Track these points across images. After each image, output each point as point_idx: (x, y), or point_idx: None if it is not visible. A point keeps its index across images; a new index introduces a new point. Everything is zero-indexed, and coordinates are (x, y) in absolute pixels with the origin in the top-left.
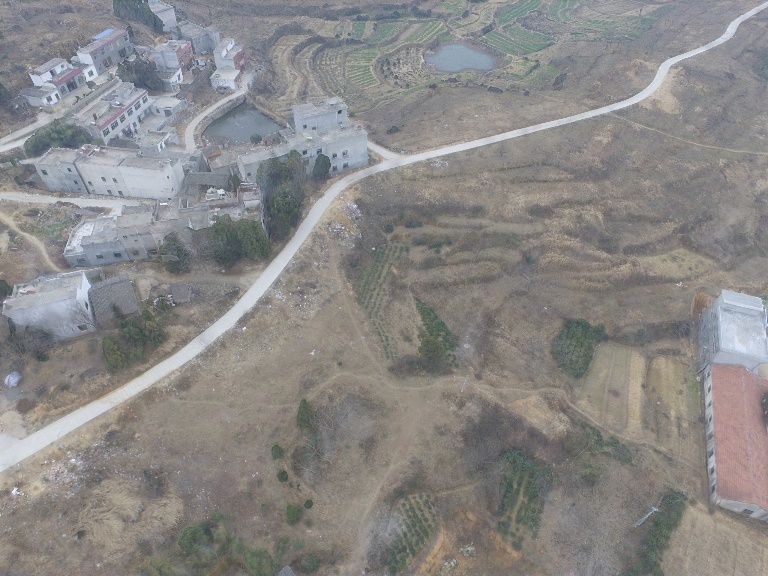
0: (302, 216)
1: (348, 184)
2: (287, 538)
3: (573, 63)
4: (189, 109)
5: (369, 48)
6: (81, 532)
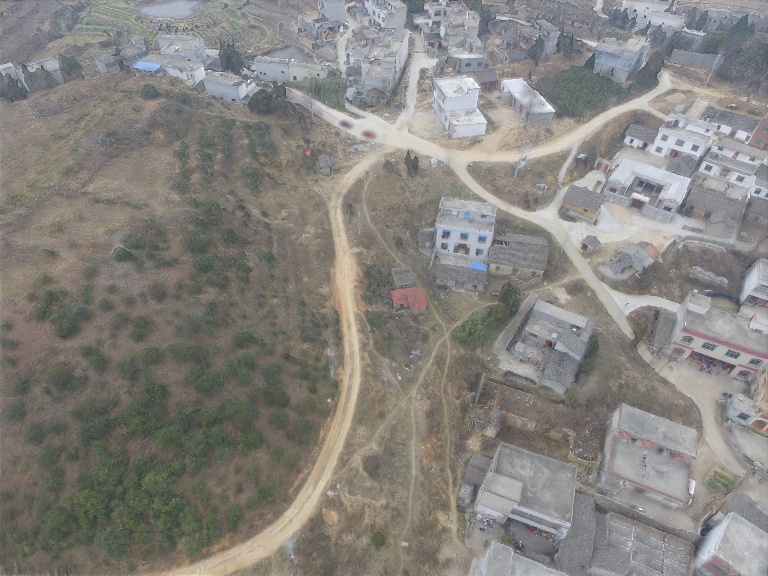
0: None
1: None
2: None
3: None
4: None
5: (129, 33)
6: None
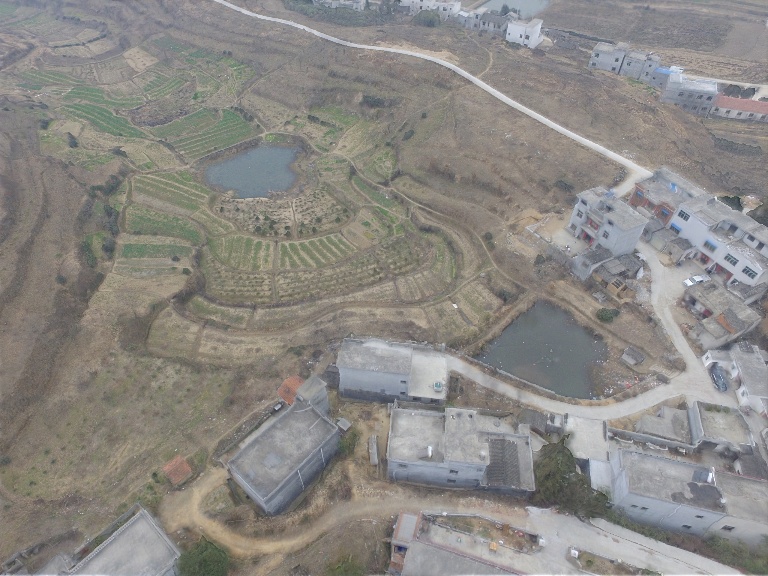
0: None
1: None
2: None
3: (337, 90)
4: None
5: (211, 246)
6: None
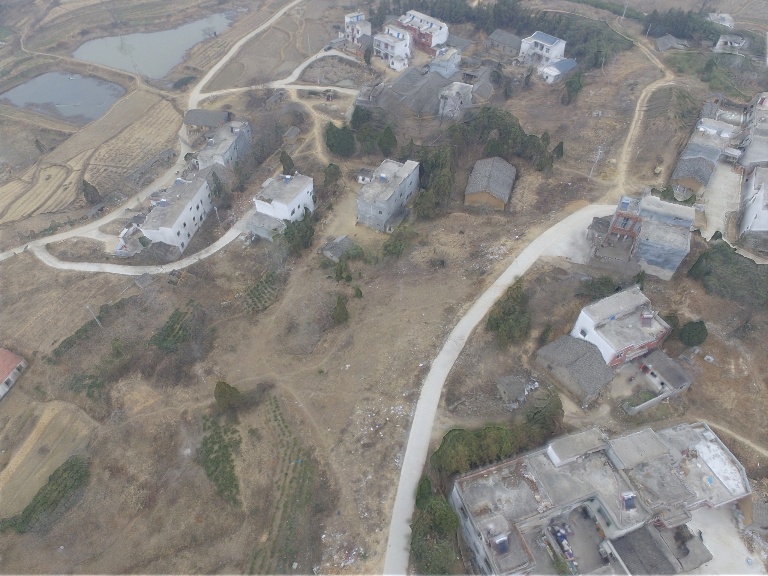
0: (414, 569)
1: None
2: None
3: None
4: None
5: None
6: (461, 232)
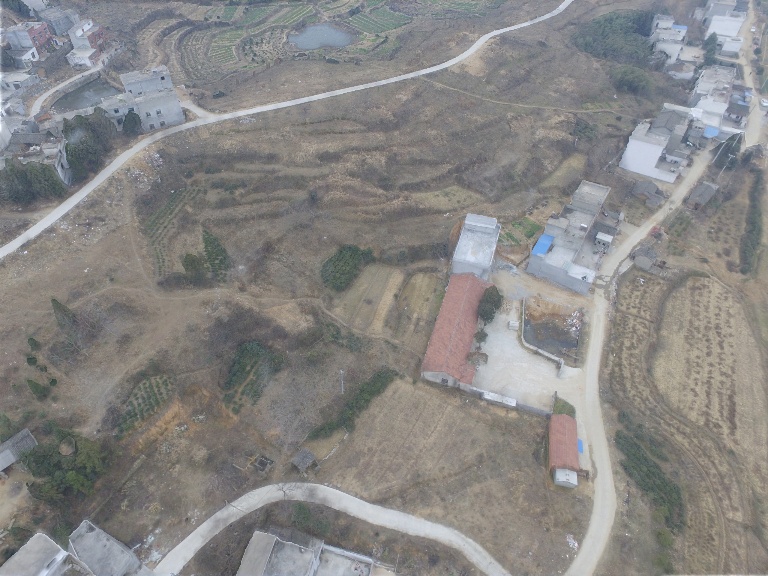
0: (105, 164)
1: (157, 138)
2: (34, 411)
3: (412, 37)
4: (41, 84)
5: (237, 30)
6: None
